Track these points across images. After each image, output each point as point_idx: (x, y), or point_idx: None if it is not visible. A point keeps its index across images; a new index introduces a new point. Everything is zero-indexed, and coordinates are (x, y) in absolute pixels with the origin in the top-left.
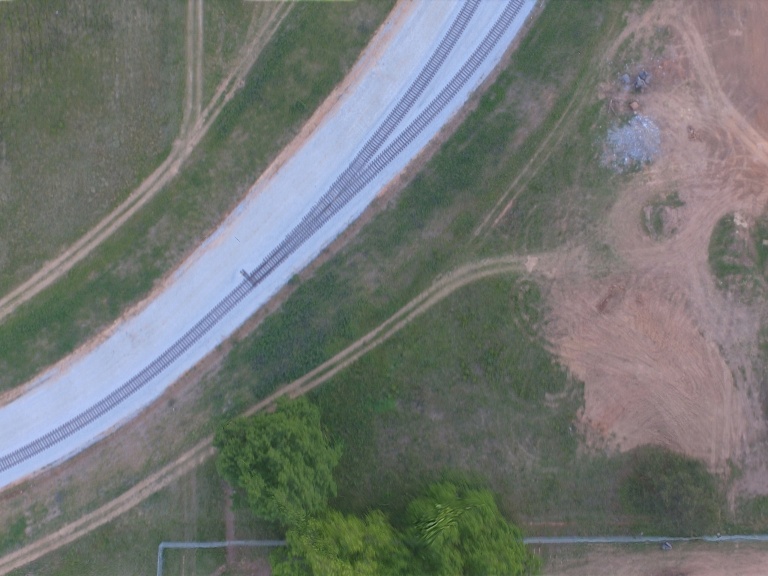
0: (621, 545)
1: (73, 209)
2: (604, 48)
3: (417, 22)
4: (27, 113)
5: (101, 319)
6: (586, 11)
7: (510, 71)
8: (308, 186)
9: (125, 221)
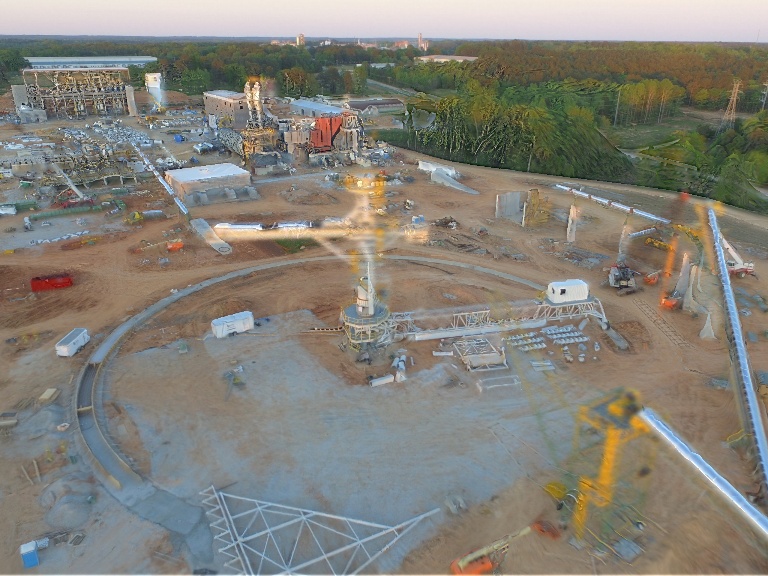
0: None
1: None
2: None
3: None
4: None
5: None
6: None
7: None
8: None
9: None
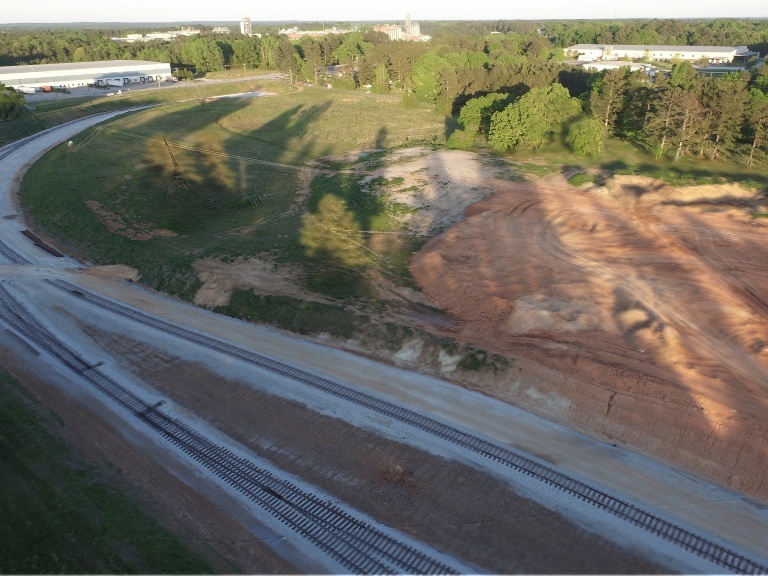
0: None
1: None
2: None
3: None
4: None
5: None
6: None
7: None
8: None
9: None
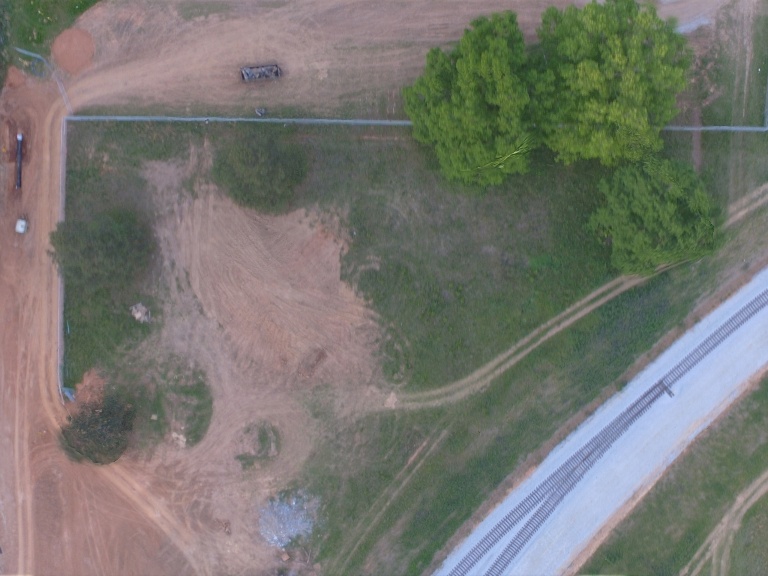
0: (307, 114)
1: None
2: None
3: None
4: None
5: None
6: None
7: None
8: (605, 478)
9: None
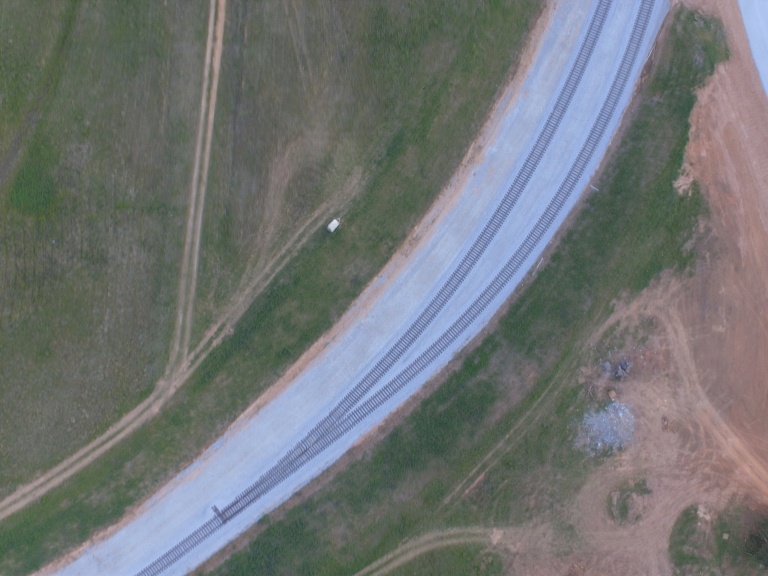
0: None
1: (51, 437)
2: (589, 333)
3: (410, 278)
4: (14, 338)
5: (70, 541)
6: (576, 292)
7: (496, 337)
8: (287, 429)
9: (102, 453)
